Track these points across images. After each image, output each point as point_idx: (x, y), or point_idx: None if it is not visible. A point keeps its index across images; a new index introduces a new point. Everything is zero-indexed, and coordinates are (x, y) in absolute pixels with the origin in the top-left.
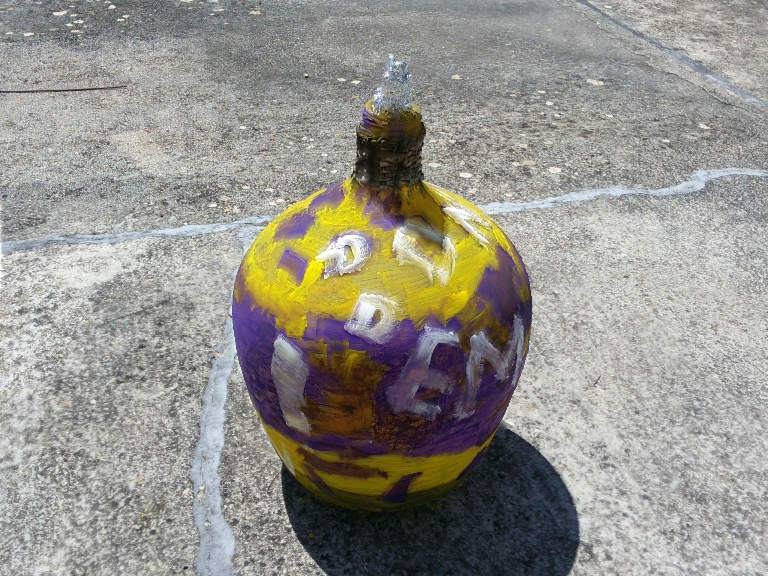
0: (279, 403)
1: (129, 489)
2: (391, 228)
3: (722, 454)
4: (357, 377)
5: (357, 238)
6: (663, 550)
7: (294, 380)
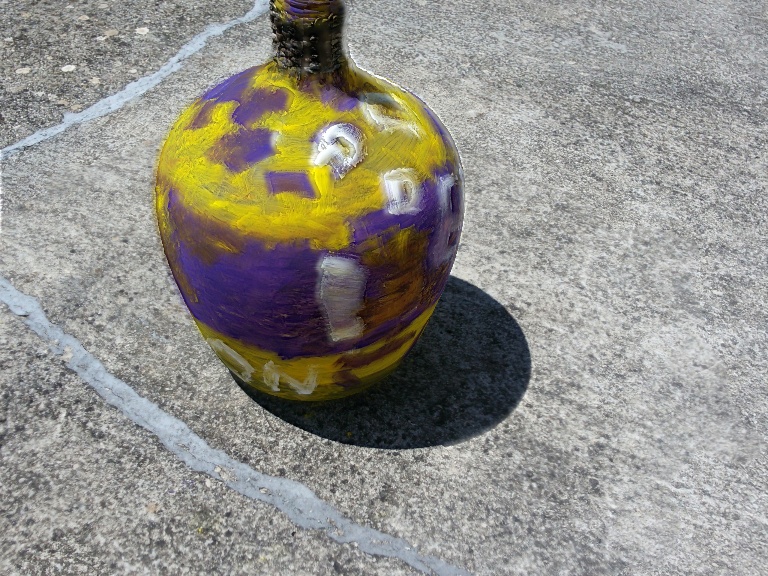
0: (329, 323)
1: (155, 522)
2: (360, 104)
3: (505, 197)
4: (413, 252)
5: (341, 126)
6: (547, 278)
7: (353, 289)
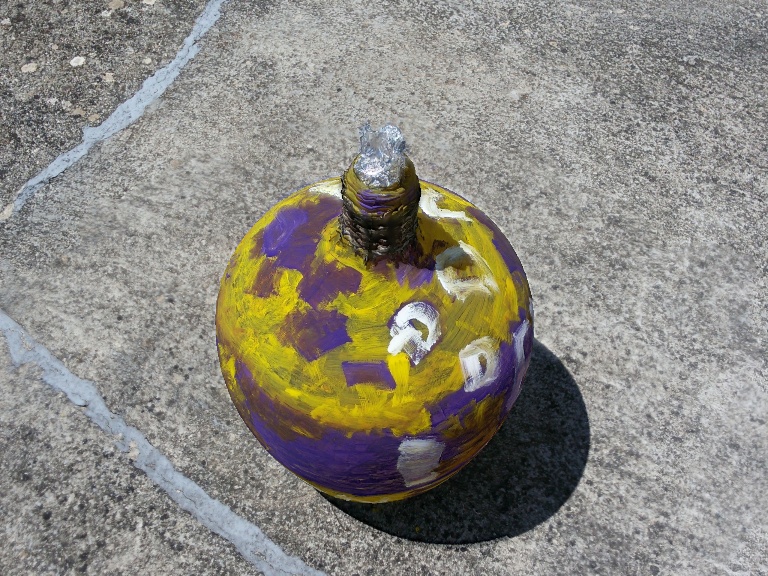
0: (403, 481)
1: None
2: (431, 274)
3: (555, 211)
4: (487, 416)
5: (413, 306)
6: (602, 319)
7: (429, 459)
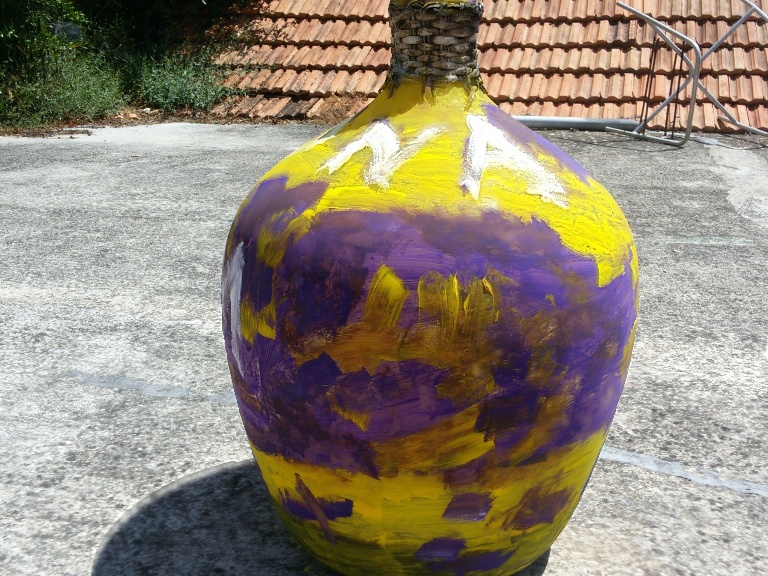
0: None
1: None
2: None
3: None
4: None
5: None
6: None
7: None
